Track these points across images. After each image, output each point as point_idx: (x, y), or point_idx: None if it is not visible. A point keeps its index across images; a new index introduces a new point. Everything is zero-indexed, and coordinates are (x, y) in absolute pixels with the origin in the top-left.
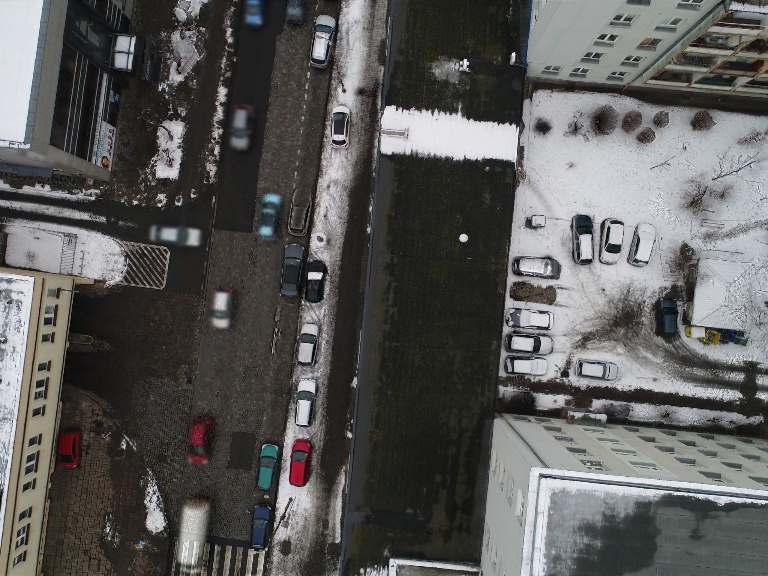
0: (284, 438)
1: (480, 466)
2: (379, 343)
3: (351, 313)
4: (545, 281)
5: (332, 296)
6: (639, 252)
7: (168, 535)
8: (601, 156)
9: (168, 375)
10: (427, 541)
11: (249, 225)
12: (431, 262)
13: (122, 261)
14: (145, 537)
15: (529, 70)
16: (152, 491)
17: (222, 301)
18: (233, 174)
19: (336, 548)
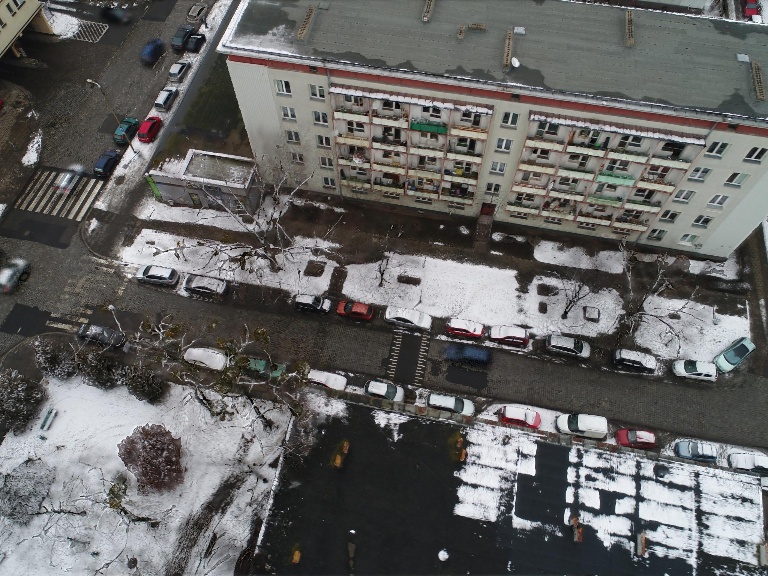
0: (144, 120)
1: None
2: None
3: None
4: None
5: None
6: None
7: (35, 168)
8: None
9: (79, 83)
10: (221, 148)
11: (164, 19)
12: None
13: (76, 28)
14: (17, 167)
15: None
16: (36, 141)
17: (132, 50)
18: None
19: None
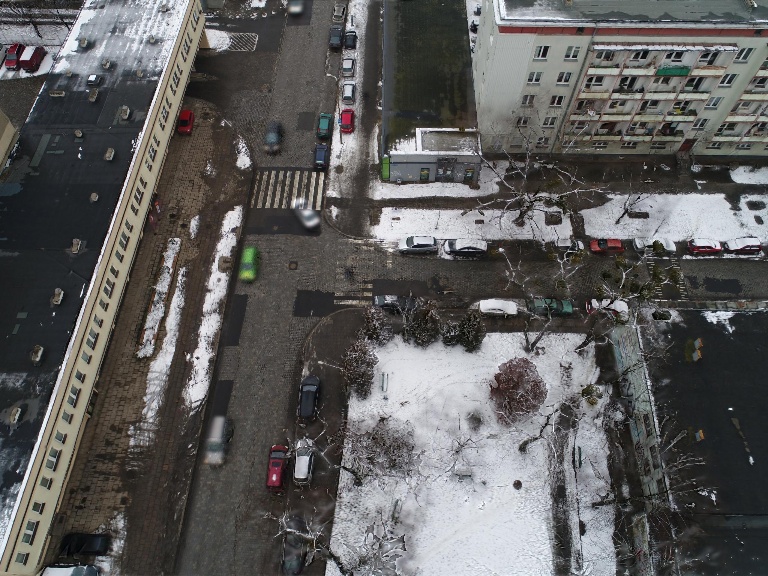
0: (335, 114)
1: (468, 89)
2: (395, 37)
3: (374, 54)
4: None
5: (361, 48)
6: None
7: (252, 170)
8: None
9: (255, 89)
10: (440, 125)
11: (308, 22)
12: (421, 6)
13: (228, 40)
14: (235, 171)
15: None
16: (242, 146)
17: (291, 54)
18: (298, 4)
19: (376, 167)
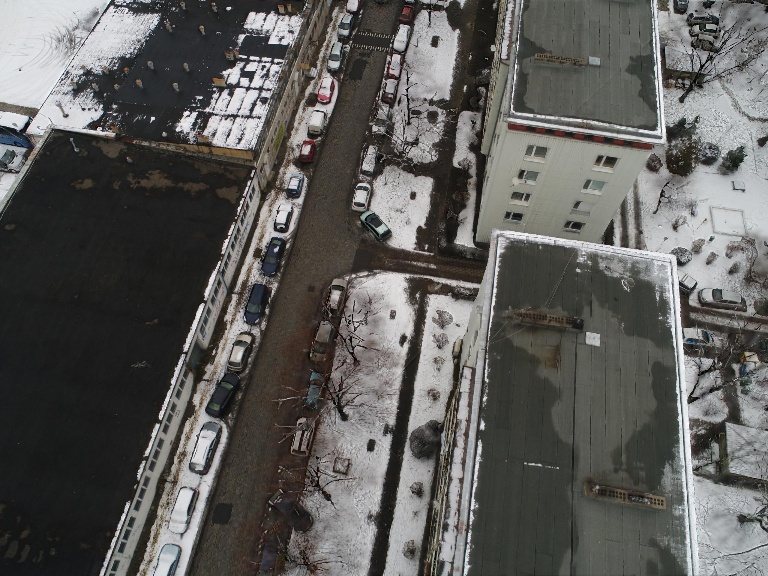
0: None
1: None
2: None
3: None
4: (672, 7)
5: None
6: None
7: None
8: (759, 33)
9: None
10: None
11: None
12: None
13: None
14: None
15: None
16: None
17: None
18: None
19: None
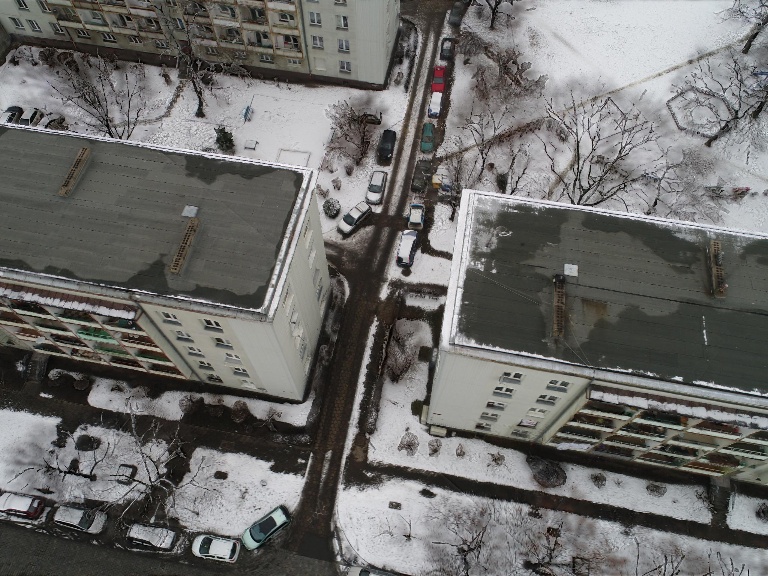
0: None
1: None
2: None
3: None
4: None
5: None
6: (38, 123)
7: None
8: (47, 79)
9: None
10: None
11: None
12: None
13: None
14: None
15: (5, 24)
16: None
17: None
18: None
19: None
